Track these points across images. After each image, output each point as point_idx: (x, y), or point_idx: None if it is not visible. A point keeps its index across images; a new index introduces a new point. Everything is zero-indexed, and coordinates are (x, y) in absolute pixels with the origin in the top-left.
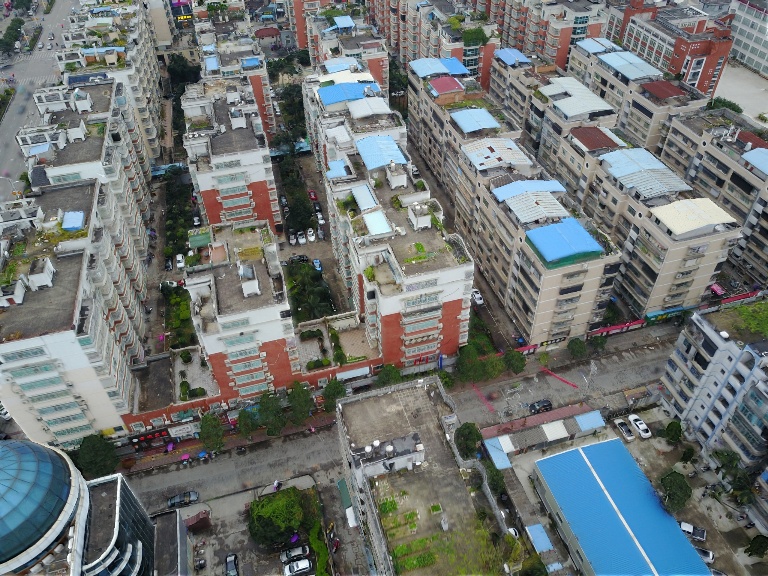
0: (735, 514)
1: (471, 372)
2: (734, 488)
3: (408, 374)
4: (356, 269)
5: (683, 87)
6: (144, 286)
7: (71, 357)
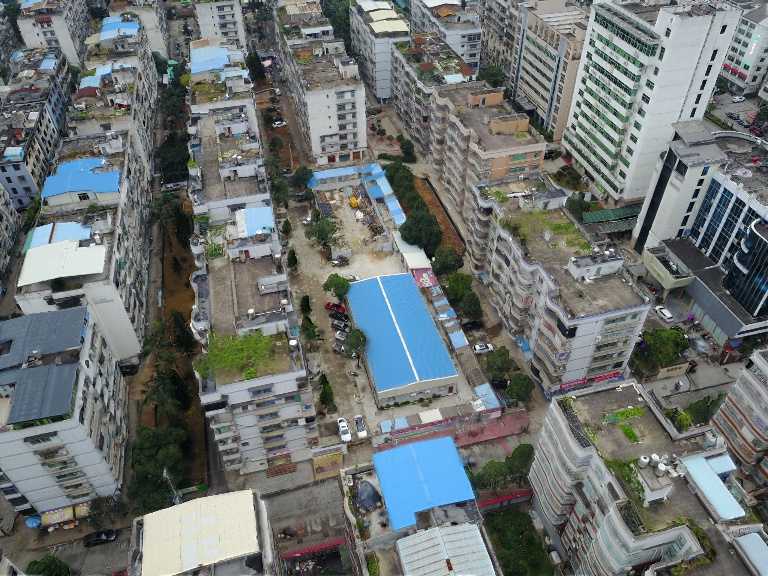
0: None
1: None
2: None
3: None
4: None
5: None
6: None
7: None
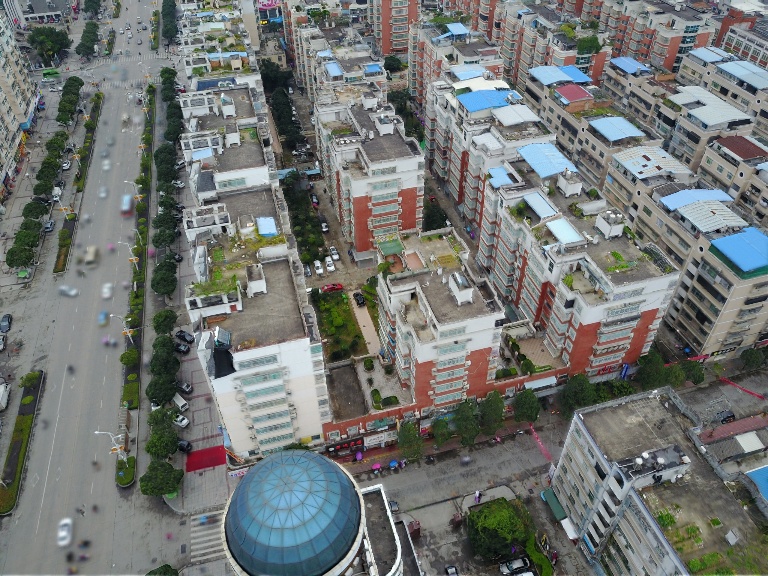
0: None
1: (656, 382)
2: None
3: (590, 384)
4: (542, 277)
5: None
6: None
7: (298, 365)
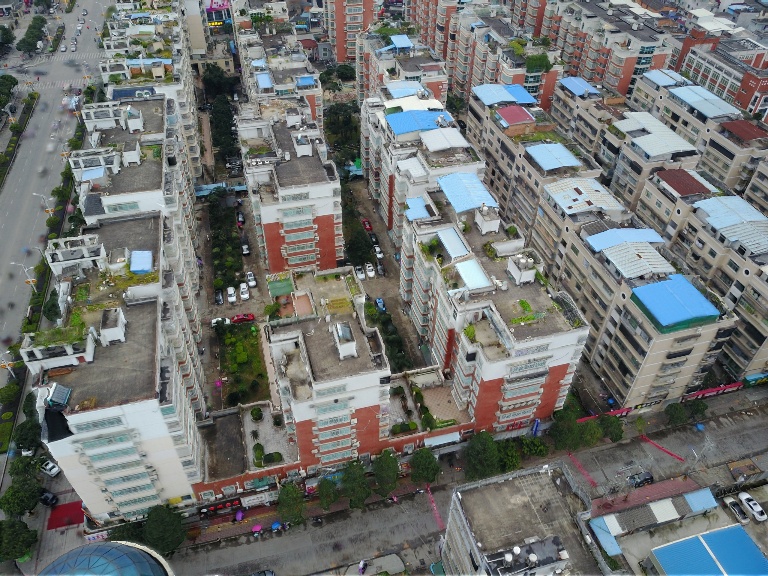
0: None
1: (569, 440)
2: None
3: (499, 439)
4: (448, 324)
5: (762, 127)
6: (200, 326)
7: (149, 426)
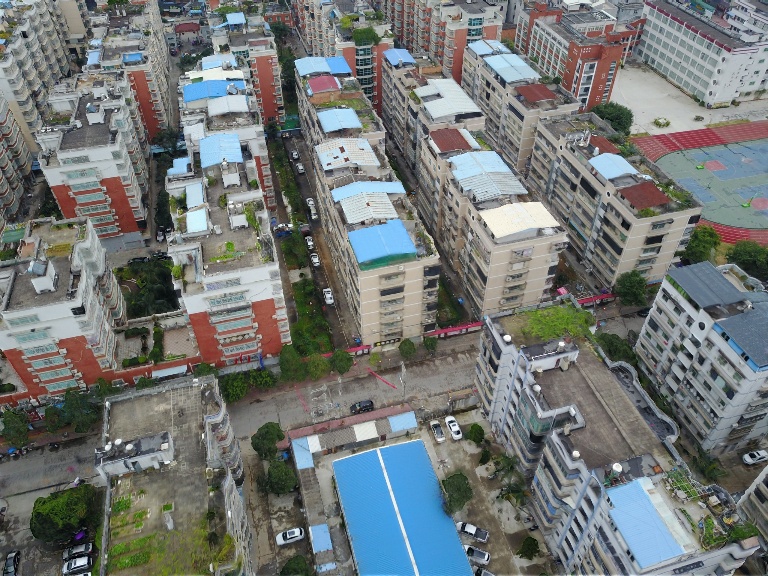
0: (523, 516)
1: (291, 372)
2: (511, 490)
3: (230, 373)
4: None
5: (560, 91)
6: None
7: None
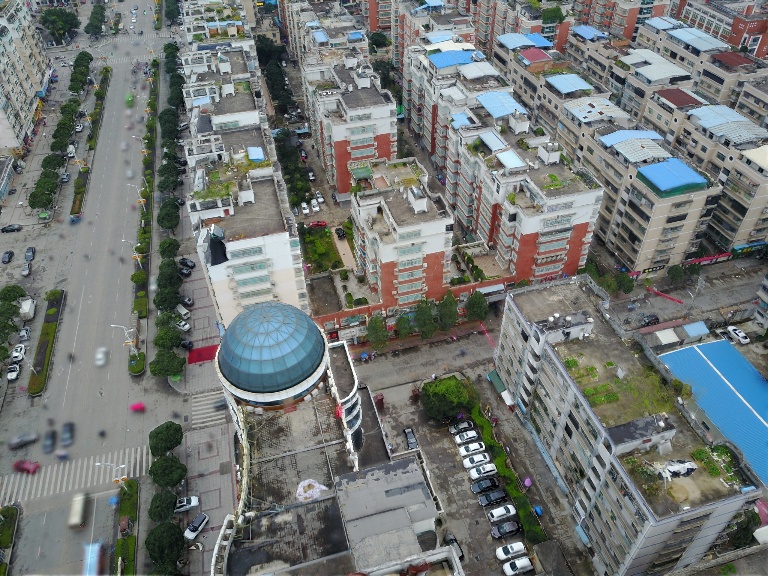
0: None
1: None
2: None
3: None
4: (492, 200)
5: (748, 58)
6: None
7: (280, 258)
